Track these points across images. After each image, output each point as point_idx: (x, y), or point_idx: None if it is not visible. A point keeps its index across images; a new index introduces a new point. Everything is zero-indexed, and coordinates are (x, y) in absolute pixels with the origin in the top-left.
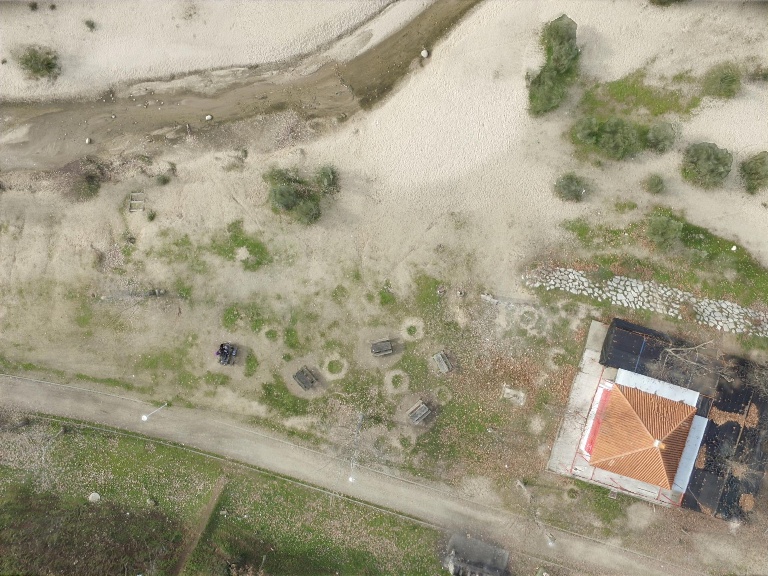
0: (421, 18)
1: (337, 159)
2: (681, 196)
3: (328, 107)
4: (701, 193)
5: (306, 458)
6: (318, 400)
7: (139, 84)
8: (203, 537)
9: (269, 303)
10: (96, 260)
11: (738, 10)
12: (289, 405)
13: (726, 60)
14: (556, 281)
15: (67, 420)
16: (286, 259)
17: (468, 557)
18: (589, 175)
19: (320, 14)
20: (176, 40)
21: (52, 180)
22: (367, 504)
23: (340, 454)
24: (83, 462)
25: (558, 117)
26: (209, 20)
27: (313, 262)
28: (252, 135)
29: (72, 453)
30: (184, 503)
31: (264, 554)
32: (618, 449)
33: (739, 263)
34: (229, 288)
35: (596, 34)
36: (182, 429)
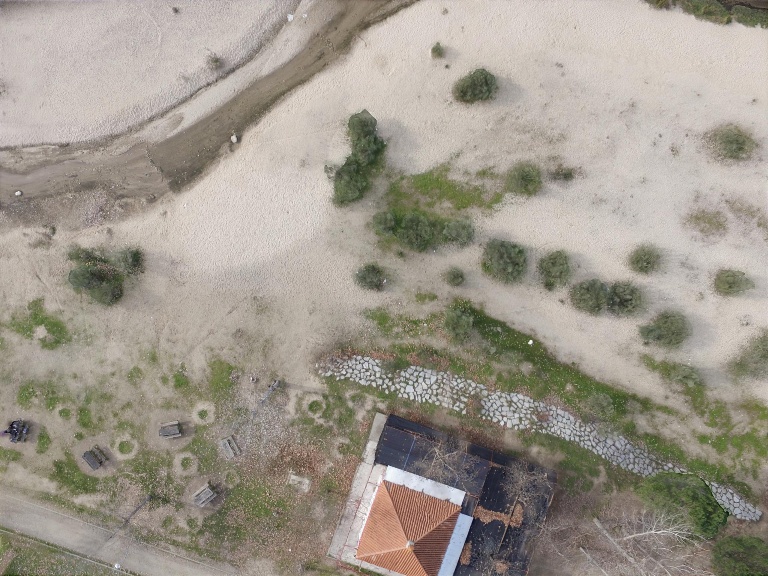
0: (232, 103)
1: (143, 240)
2: (481, 289)
3: (137, 188)
4: (500, 287)
5: (95, 535)
6: (108, 479)
7: None
8: None
9: (65, 381)
10: None
11: (540, 111)
12: (79, 483)
13: (528, 159)
14: (348, 371)
15: None
16: (84, 338)
17: None
18: (391, 265)
19: (129, 97)
20: None
21: None
22: None
23: None
24: None
25: (362, 207)
26: (18, 98)
27: (111, 342)
28: (61, 212)
29: None
30: None
31: None
32: (379, 546)
33: (535, 357)
34: (26, 365)
35: (402, 128)
36: None
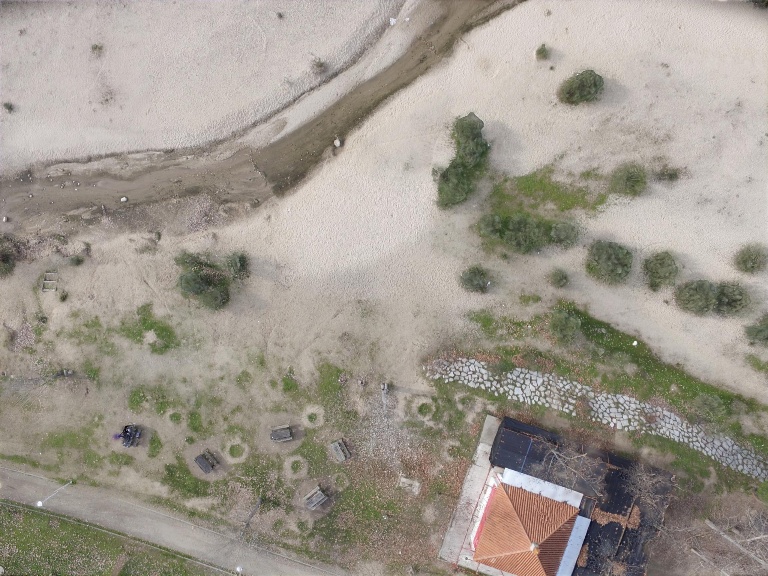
0: (335, 108)
1: (248, 244)
2: (585, 291)
3: (241, 192)
4: (604, 288)
5: (206, 538)
6: (219, 482)
7: (56, 165)
8: None
9: (175, 386)
10: (7, 339)
11: (645, 111)
12: (190, 487)
13: (632, 159)
14: (456, 373)
15: None
16: (193, 343)
17: None
18: (495, 267)
19: (234, 102)
20: (93, 124)
21: None
22: None
23: (239, 535)
24: None
25: (466, 210)
26: (125, 105)
27: (219, 347)
28: (166, 218)
29: None
30: None
31: None
32: (499, 548)
33: (640, 358)
34: (136, 370)
35: (505, 130)
36: (86, 506)
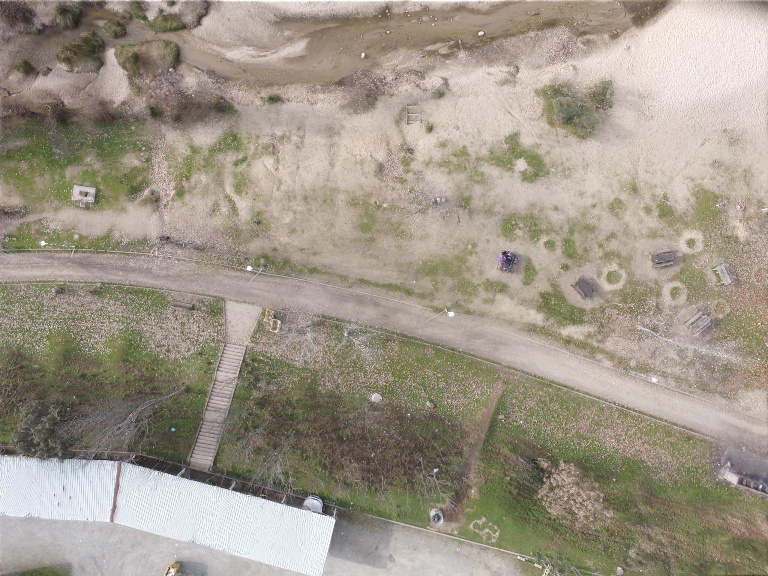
0: None
1: (609, 75)
2: None
3: (600, 24)
4: None
5: (582, 367)
6: (595, 310)
7: None
8: (487, 438)
9: (546, 214)
10: (377, 169)
11: None
12: (567, 314)
13: None
14: None
15: (349, 323)
16: (562, 171)
17: (744, 470)
18: None
19: None
20: None
21: (328, 93)
22: (642, 414)
23: (616, 364)
24: (365, 364)
25: None
26: None
27: (589, 175)
28: (523, 51)
29: (355, 355)
30: (462, 407)
31: (544, 458)
32: None
33: None
34: (507, 199)
35: None
36: (460, 335)
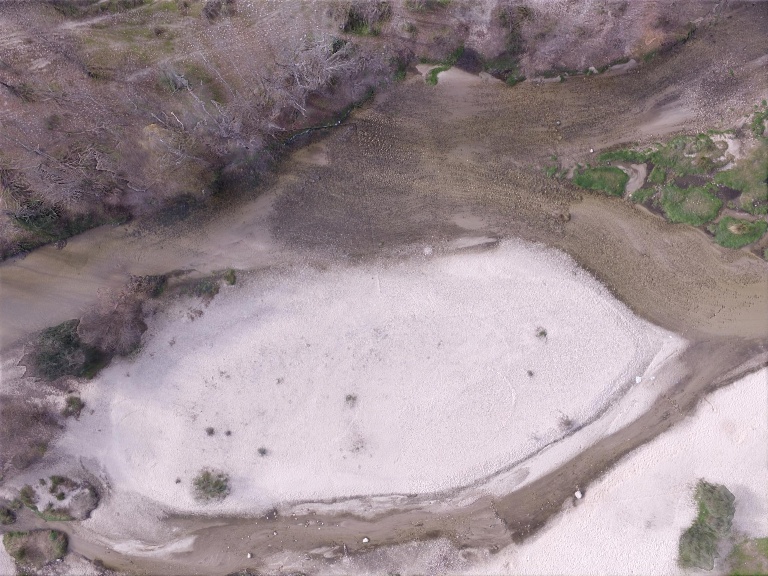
0: (577, 460)
1: None
2: None
3: (481, 538)
4: None
5: None
6: None
7: (302, 504)
8: None
9: None
10: None
11: None
12: None
13: None
14: None
15: None
16: None
17: None
18: None
19: (481, 455)
20: (342, 469)
21: None
22: None
23: None
24: None
25: None
26: (375, 454)
27: None
28: (406, 560)
29: None
30: None
31: None
32: None
33: None
34: None
35: (749, 493)
36: None
